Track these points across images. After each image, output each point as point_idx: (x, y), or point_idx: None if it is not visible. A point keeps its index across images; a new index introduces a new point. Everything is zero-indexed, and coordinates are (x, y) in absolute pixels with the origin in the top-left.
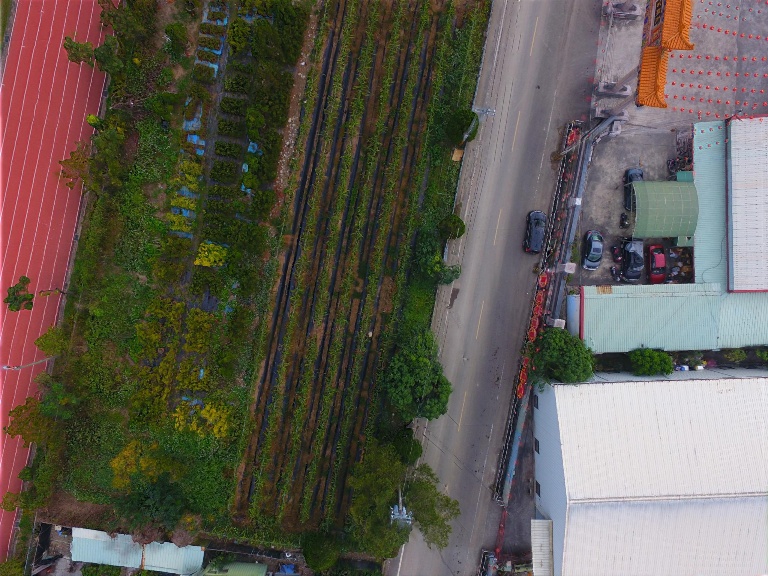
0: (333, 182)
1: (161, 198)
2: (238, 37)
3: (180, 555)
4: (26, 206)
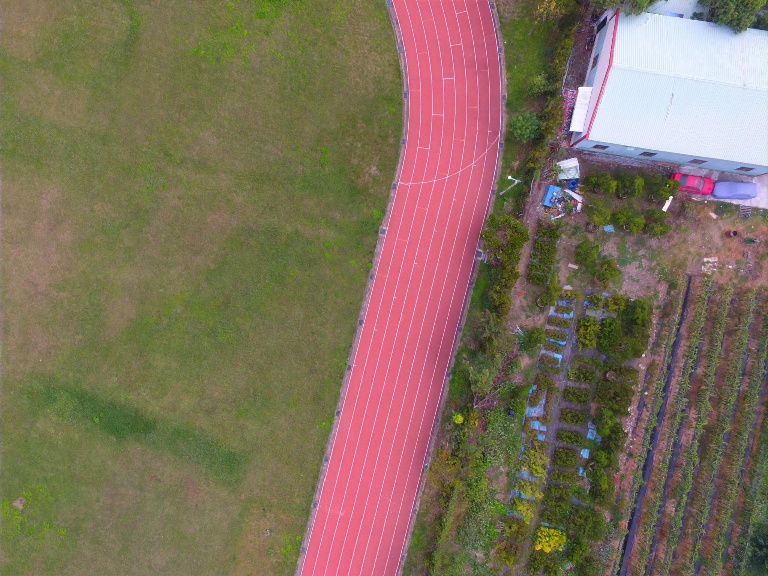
0: None
1: (502, 480)
2: (589, 334)
3: None
4: (370, 481)
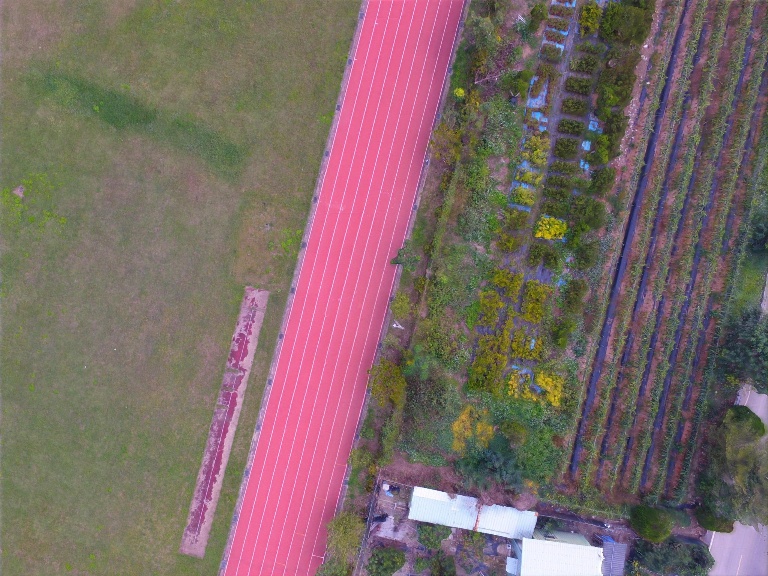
0: (668, 162)
1: (502, 172)
2: (591, 19)
3: (514, 519)
4: (370, 176)
